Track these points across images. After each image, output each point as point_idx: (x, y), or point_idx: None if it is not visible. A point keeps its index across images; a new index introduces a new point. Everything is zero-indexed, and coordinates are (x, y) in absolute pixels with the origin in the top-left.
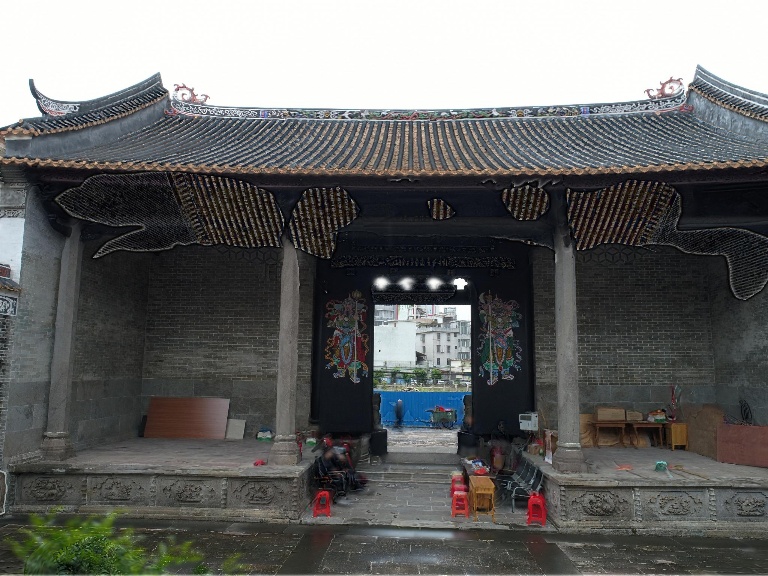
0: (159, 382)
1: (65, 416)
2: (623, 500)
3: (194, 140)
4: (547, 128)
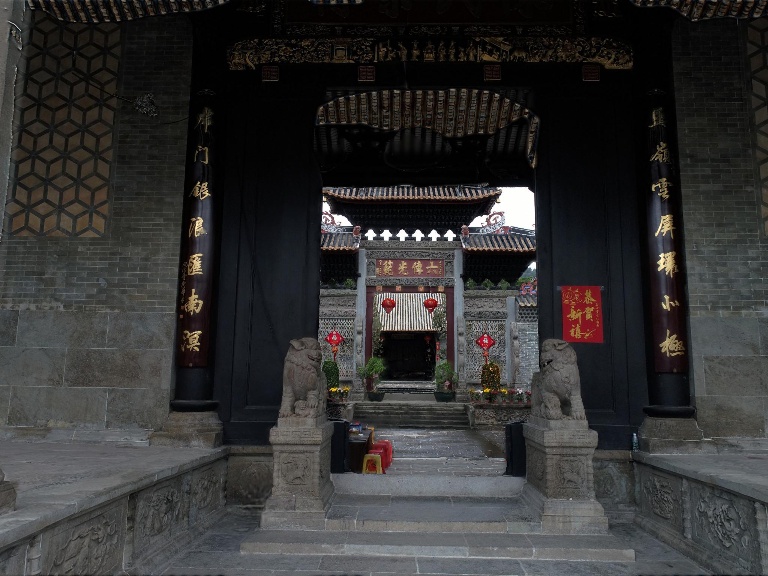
0: None
1: None
2: None
3: (741, 6)
4: None
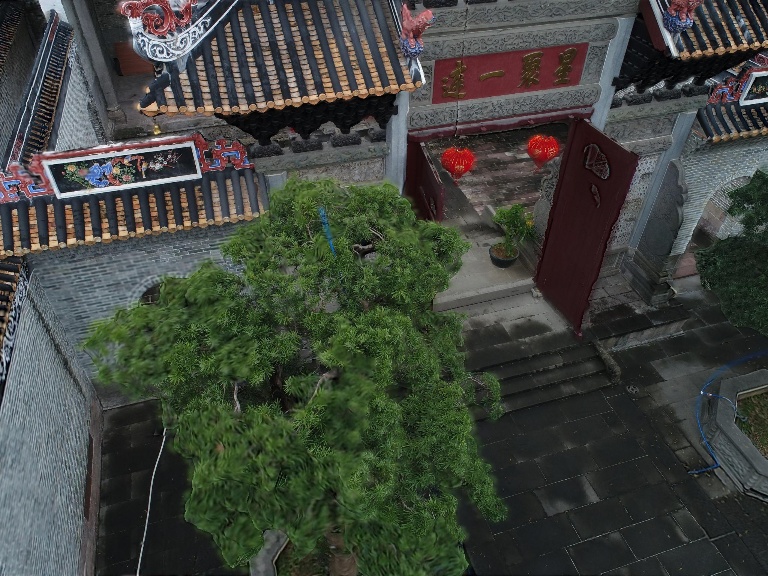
0: (116, 31)
1: (115, 96)
2: None
3: None
4: None
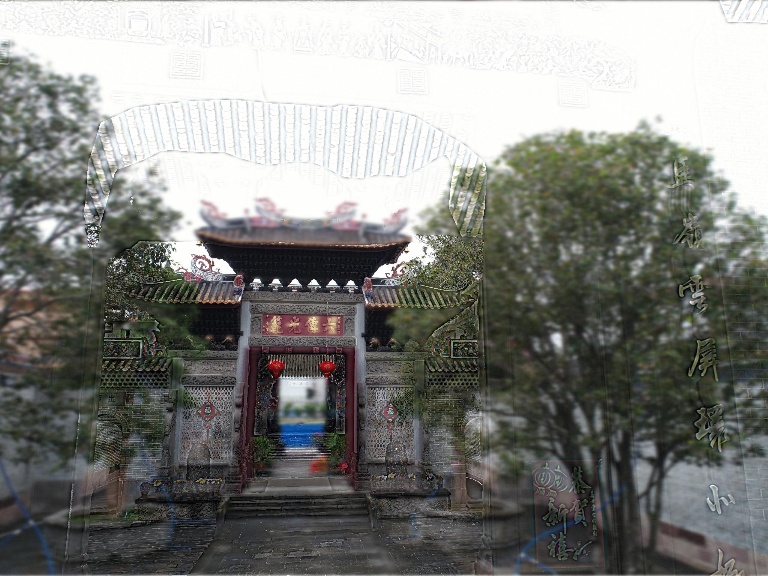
0: None
1: None
2: None
3: None
4: None
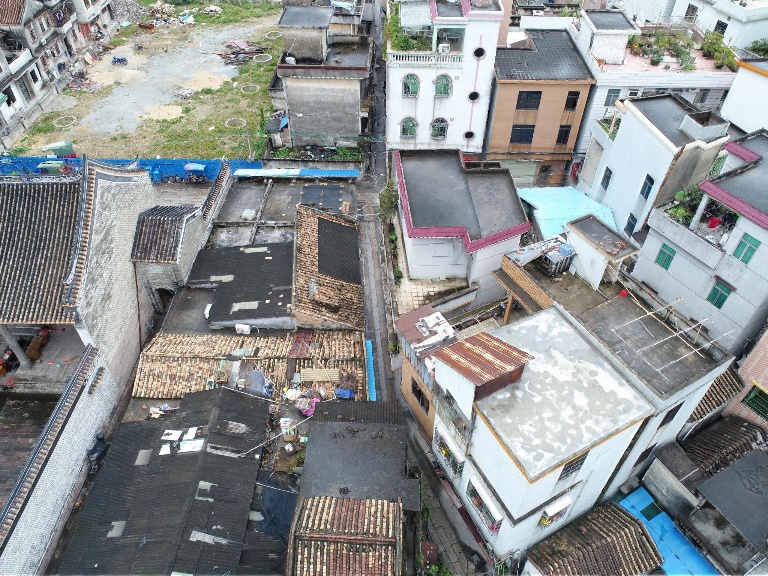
0: None
1: None
2: (34, 385)
3: None
4: (0, 201)
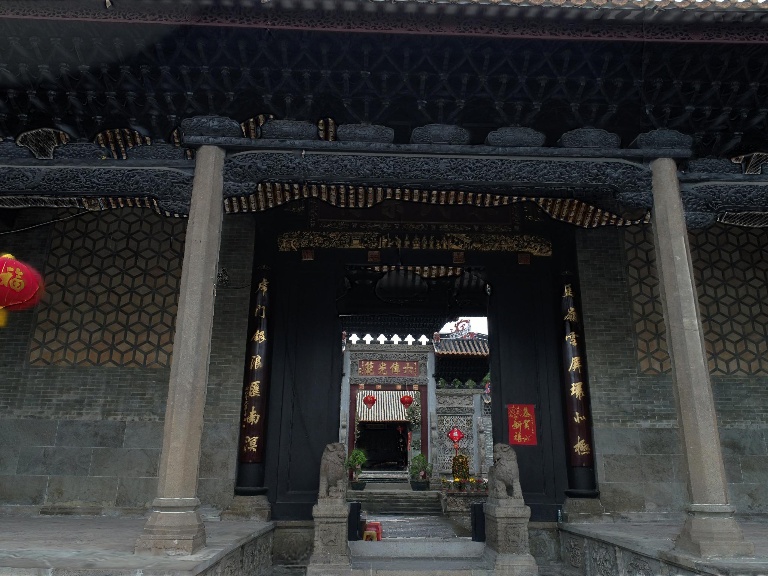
0: None
1: None
2: None
3: None
4: None
